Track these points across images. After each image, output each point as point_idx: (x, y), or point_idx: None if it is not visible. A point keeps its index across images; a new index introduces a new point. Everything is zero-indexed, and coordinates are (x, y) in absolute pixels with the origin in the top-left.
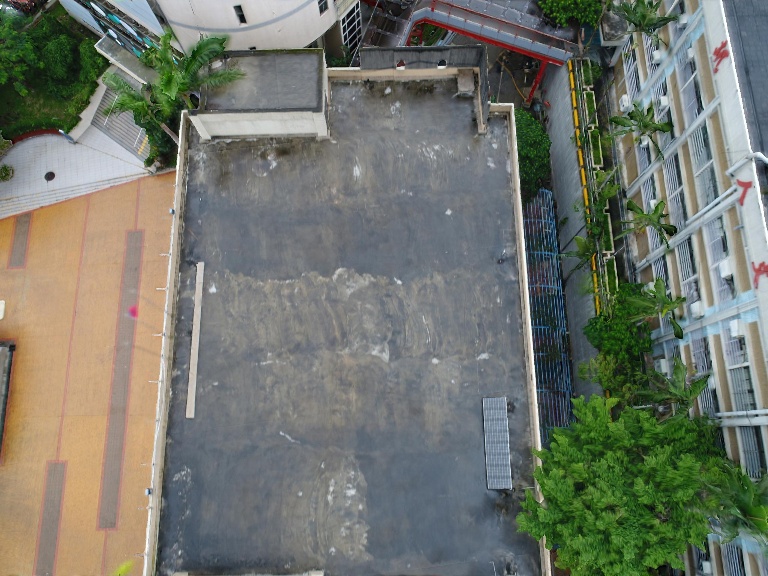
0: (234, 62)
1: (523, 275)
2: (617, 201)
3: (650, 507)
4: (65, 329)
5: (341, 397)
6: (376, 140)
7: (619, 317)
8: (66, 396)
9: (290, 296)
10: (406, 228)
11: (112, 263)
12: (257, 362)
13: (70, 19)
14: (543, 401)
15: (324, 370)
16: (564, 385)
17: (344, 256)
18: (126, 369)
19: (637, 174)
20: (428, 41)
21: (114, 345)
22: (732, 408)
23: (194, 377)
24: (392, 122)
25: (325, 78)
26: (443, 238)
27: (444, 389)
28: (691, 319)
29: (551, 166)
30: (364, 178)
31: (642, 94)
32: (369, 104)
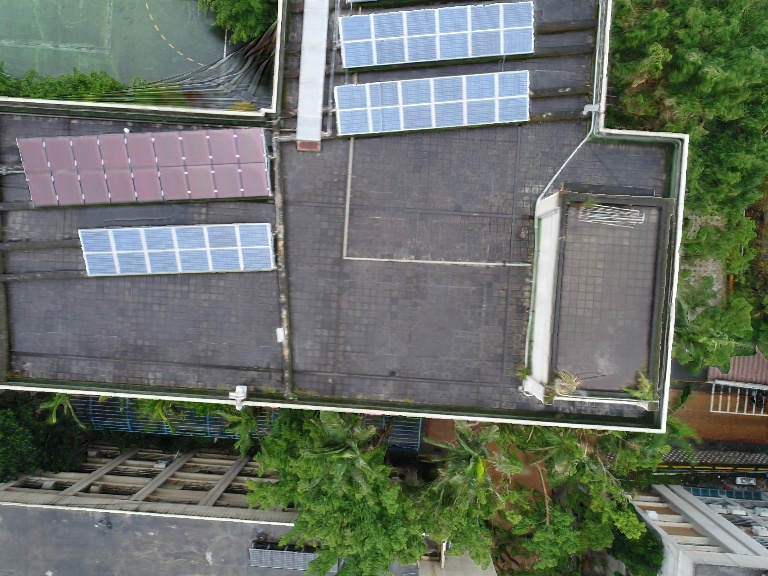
0: None
1: None
2: None
3: (348, 483)
4: None
5: None
6: None
7: (181, 403)
8: None
9: None
10: None
11: None
12: None
13: None
14: None
15: None
16: None
17: None
18: None
19: None
20: None
21: None
22: None
23: None
24: None
25: None
26: None
27: None
28: None
29: None
30: None
31: None
32: None
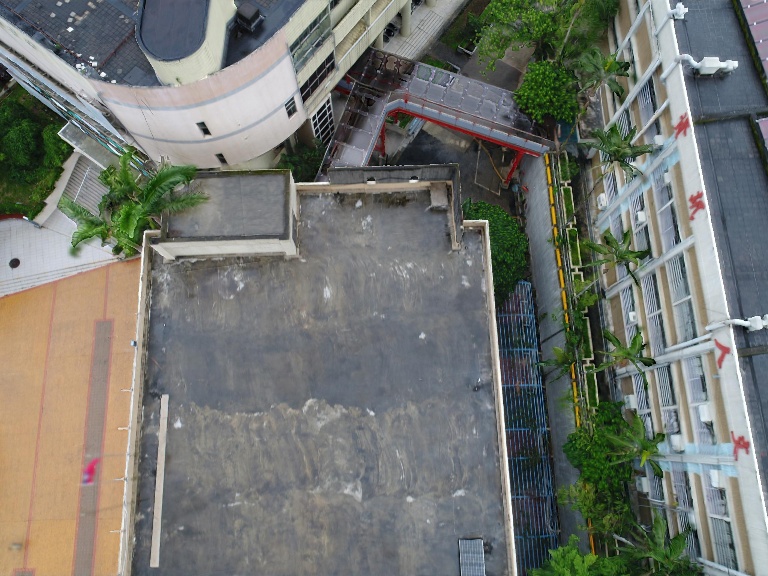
0: (197, 184)
1: (499, 405)
2: (596, 302)
3: None
4: (32, 427)
5: (312, 541)
6: (347, 258)
7: (598, 445)
8: (33, 499)
9: (259, 430)
10: (379, 354)
11: (80, 355)
12: (224, 504)
13: (34, 98)
14: (524, 508)
15: (294, 511)
16: (545, 490)
17: (314, 386)
18: (96, 469)
19: (616, 279)
20: (404, 119)
21: (83, 443)
22: (714, 558)
23: (158, 522)
24: (363, 238)
25: (293, 197)
26: (417, 364)
27: (419, 530)
28: (671, 450)
29: (530, 252)
30: (335, 300)
31: (619, 200)
32: (339, 219)
